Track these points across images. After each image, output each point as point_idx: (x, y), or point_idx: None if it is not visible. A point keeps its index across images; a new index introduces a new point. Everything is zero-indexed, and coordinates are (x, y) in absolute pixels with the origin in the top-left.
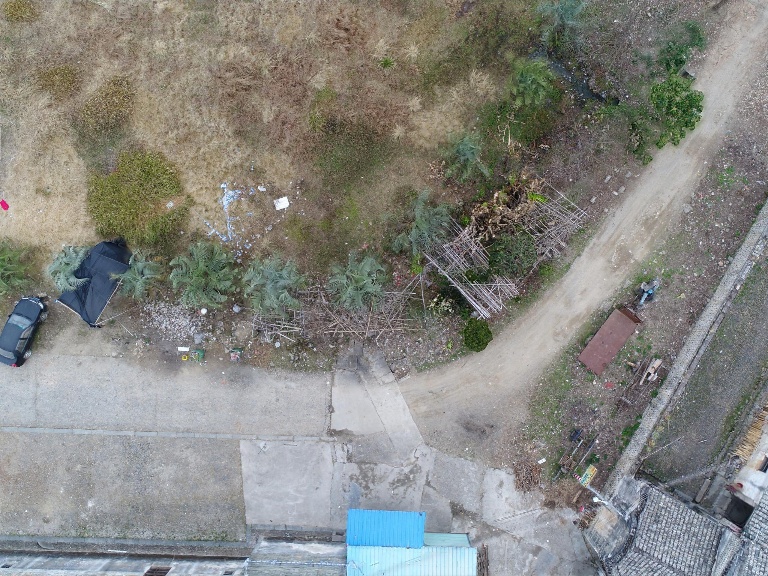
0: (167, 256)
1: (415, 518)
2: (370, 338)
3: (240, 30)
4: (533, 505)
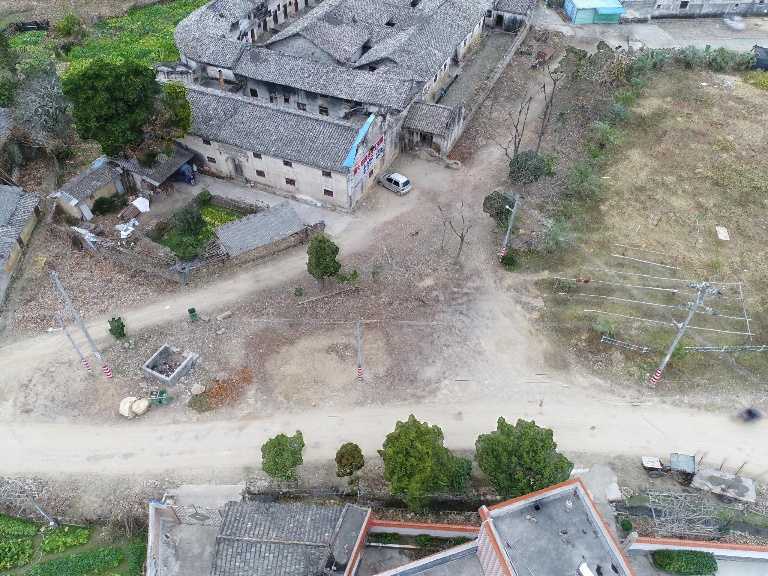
0: (741, 70)
1: None
2: None
3: (767, 123)
4: None
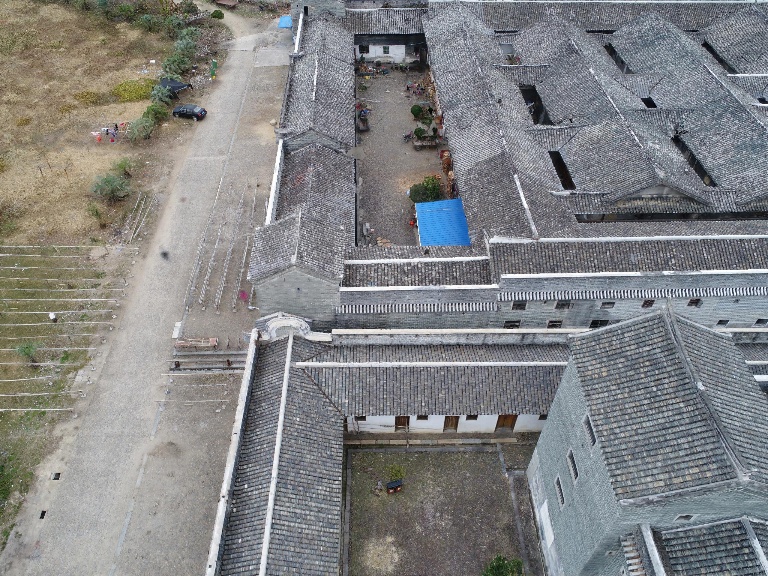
0: None
1: (282, 17)
2: None
3: None
4: (287, 15)
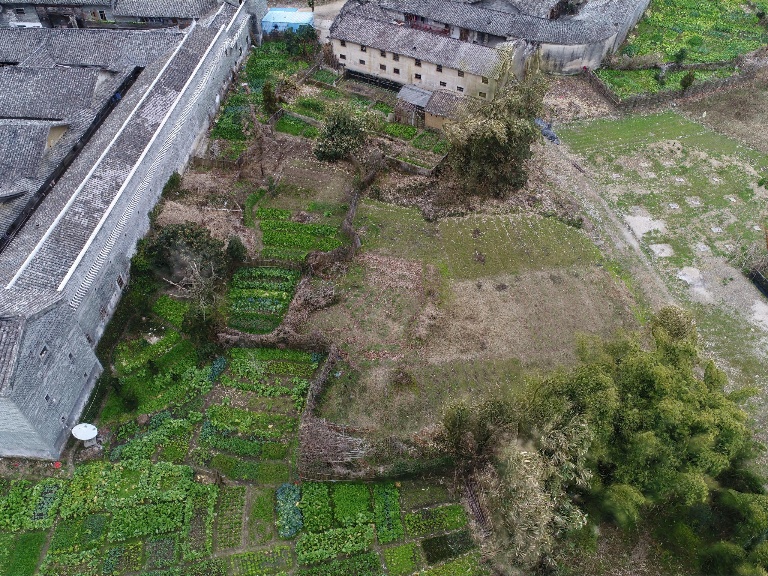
0: None
1: None
2: (288, 3)
3: None
4: None
